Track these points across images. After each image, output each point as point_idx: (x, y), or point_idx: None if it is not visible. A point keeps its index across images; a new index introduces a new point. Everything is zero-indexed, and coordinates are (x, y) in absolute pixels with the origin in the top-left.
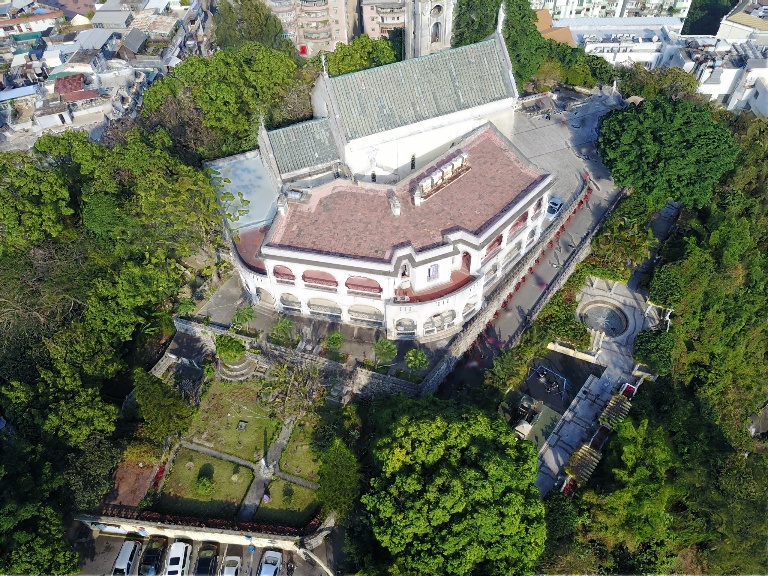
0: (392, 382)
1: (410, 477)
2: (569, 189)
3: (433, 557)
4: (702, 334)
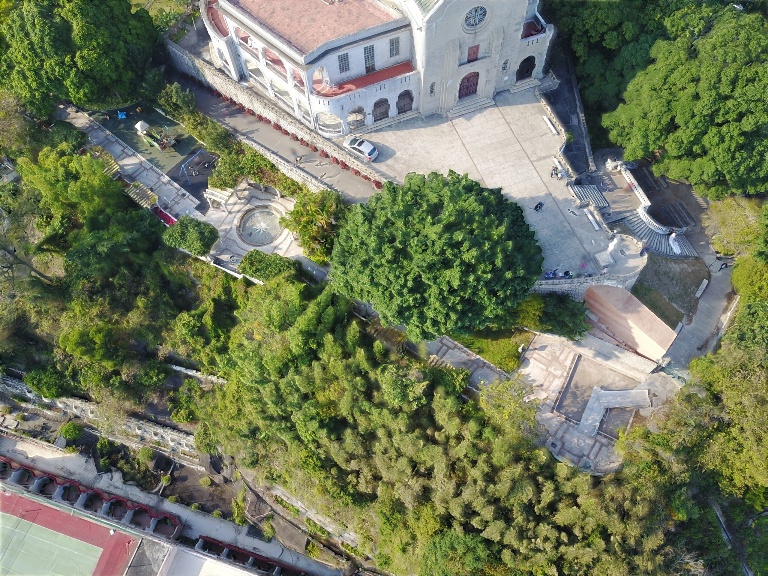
0: None
1: None
2: (402, 175)
3: None
4: None
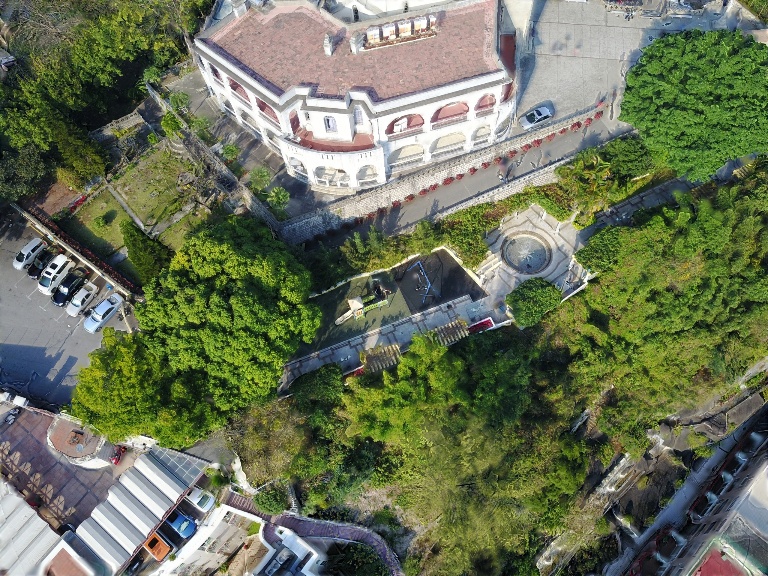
0: (263, 210)
1: (172, 277)
2: (577, 105)
3: (161, 345)
4: (622, 315)
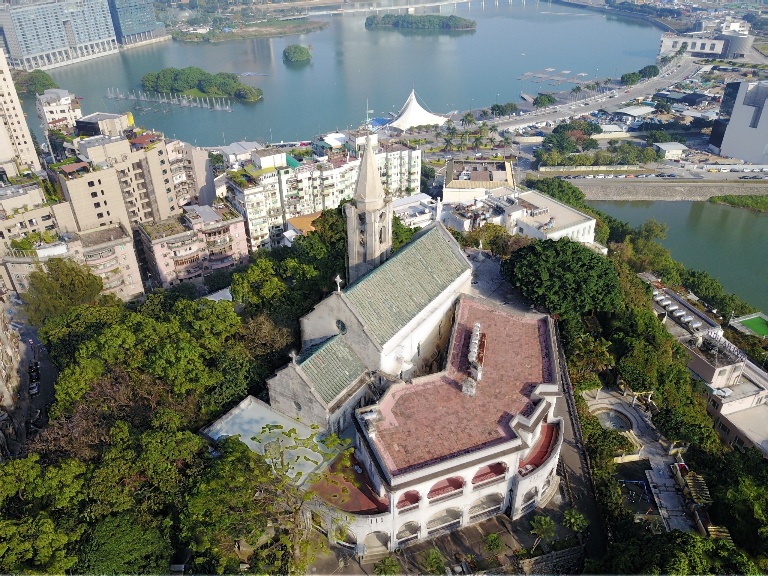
0: (555, 558)
1: None
2: None
3: None
4: (669, 403)
